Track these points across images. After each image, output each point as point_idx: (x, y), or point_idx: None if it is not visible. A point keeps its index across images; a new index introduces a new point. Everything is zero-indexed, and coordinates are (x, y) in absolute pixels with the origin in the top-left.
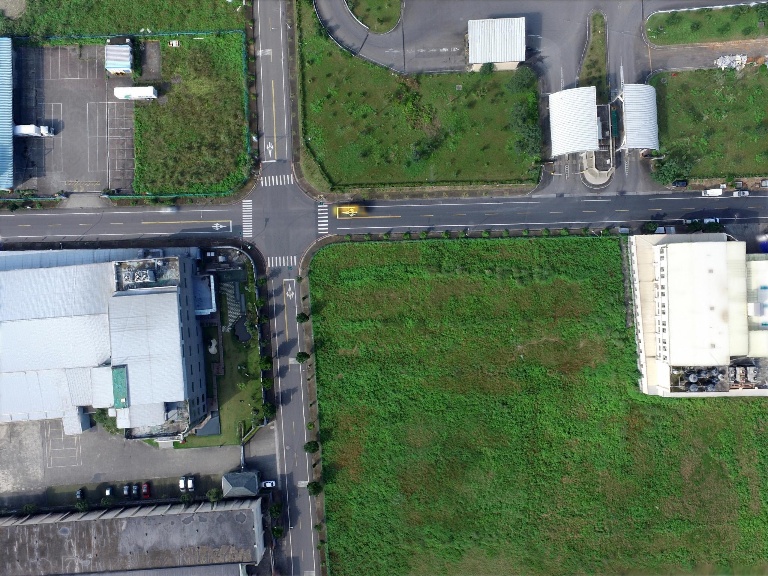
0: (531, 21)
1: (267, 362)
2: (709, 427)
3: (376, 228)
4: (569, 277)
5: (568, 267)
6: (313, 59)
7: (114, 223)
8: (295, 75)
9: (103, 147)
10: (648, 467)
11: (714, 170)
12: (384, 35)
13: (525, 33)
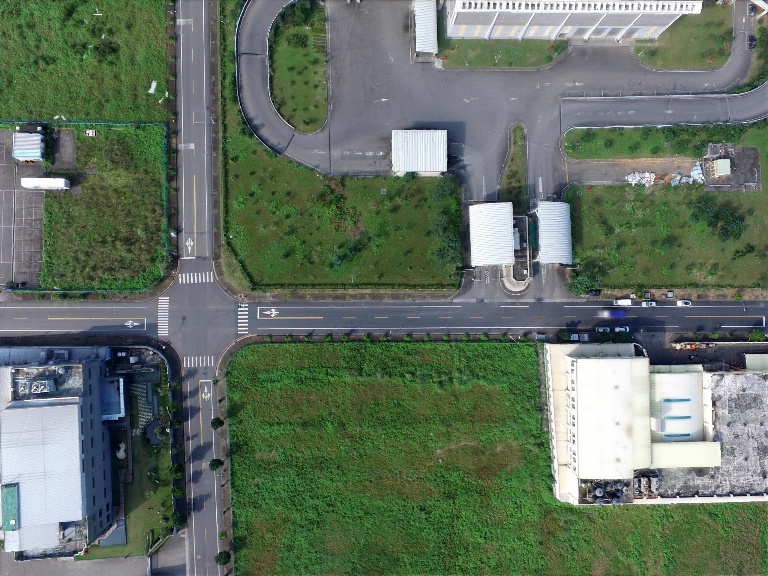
0: (455, 130)
1: (177, 471)
2: (618, 530)
3: (297, 329)
4: (487, 382)
5: (487, 372)
6: (237, 156)
7: (17, 318)
8: (218, 171)
9: (8, 237)
10: (560, 571)
11: (625, 280)
12: (310, 136)
13: (449, 142)
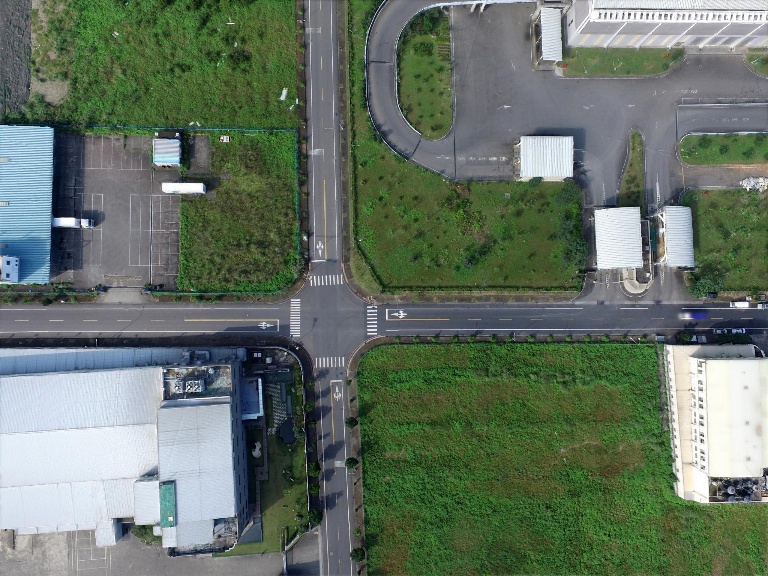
0: (575, 136)
1: (316, 470)
2: (737, 527)
3: (425, 330)
4: (610, 382)
5: (608, 372)
6: (366, 161)
7: (155, 320)
8: (347, 176)
9: (146, 241)
10: (682, 568)
11: (740, 283)
12: (436, 142)
13: None
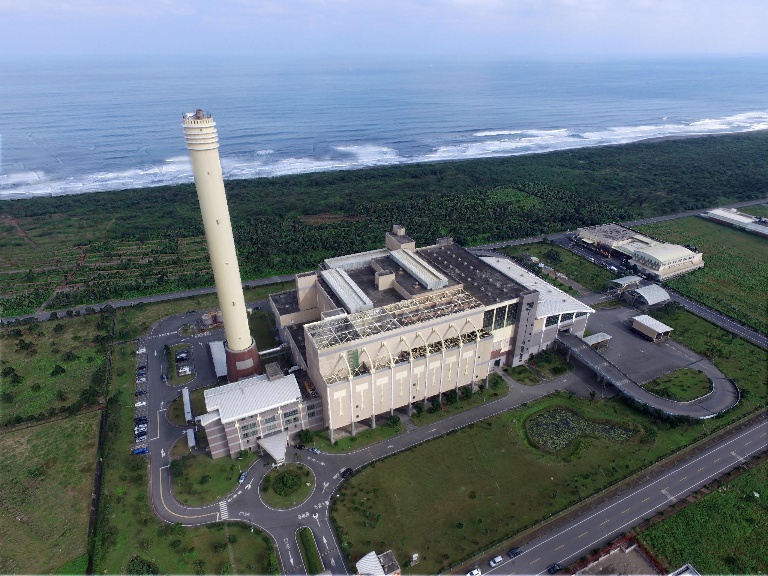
0: (619, 325)
1: None
2: None
3: None
4: None
5: None
6: (760, 398)
7: None
8: None
9: None
10: None
11: None
12: None
13: None
